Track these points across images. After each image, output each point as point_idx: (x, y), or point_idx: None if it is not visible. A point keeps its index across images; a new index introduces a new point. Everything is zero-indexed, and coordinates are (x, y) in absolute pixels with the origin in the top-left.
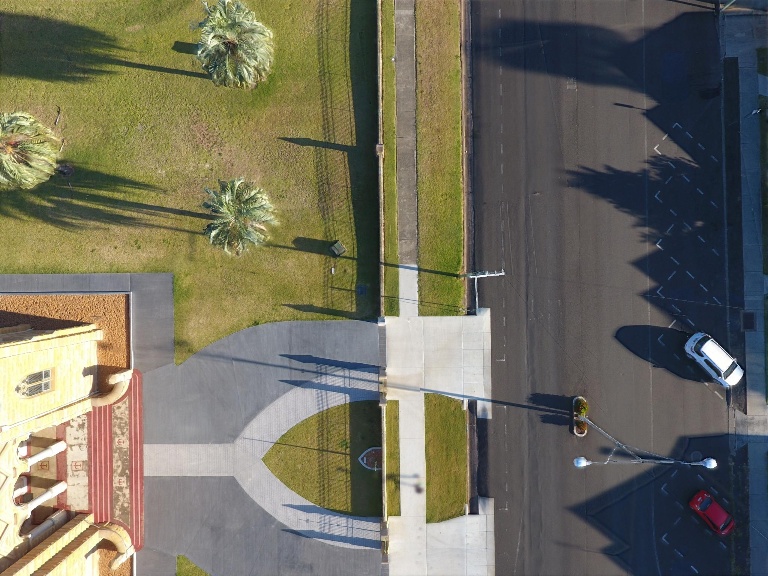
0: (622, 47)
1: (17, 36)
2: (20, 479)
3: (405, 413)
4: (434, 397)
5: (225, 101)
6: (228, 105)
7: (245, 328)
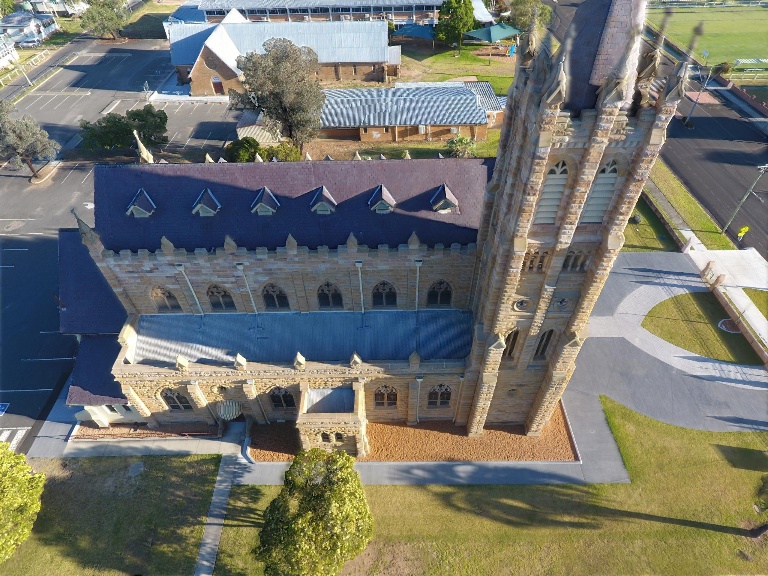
0: (744, 155)
1: (420, 154)
2: None
3: (735, 299)
4: (750, 290)
5: None
6: None
7: None
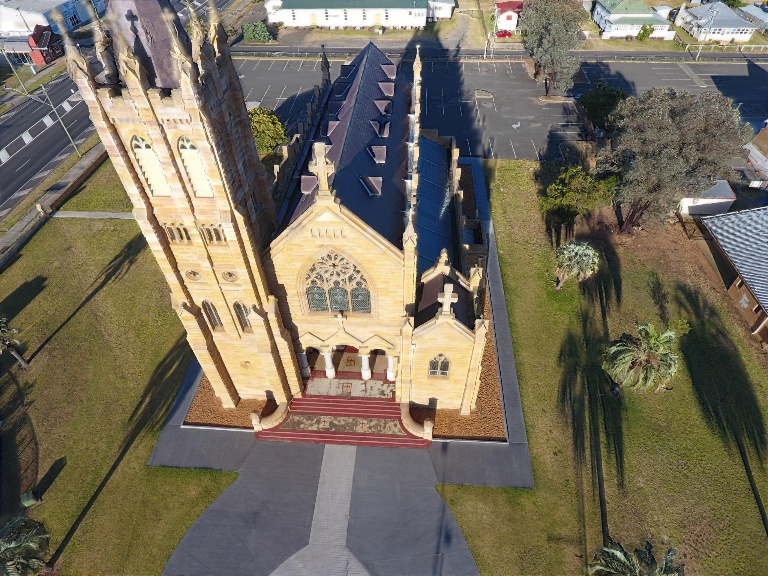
0: None
1: (723, 360)
2: (343, 345)
3: None
4: None
5: (754, 567)
6: (750, 571)
7: (481, 574)
